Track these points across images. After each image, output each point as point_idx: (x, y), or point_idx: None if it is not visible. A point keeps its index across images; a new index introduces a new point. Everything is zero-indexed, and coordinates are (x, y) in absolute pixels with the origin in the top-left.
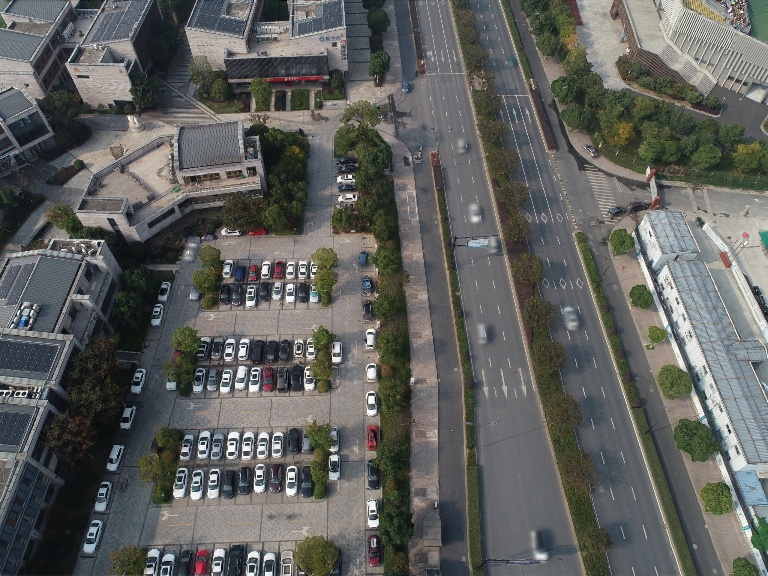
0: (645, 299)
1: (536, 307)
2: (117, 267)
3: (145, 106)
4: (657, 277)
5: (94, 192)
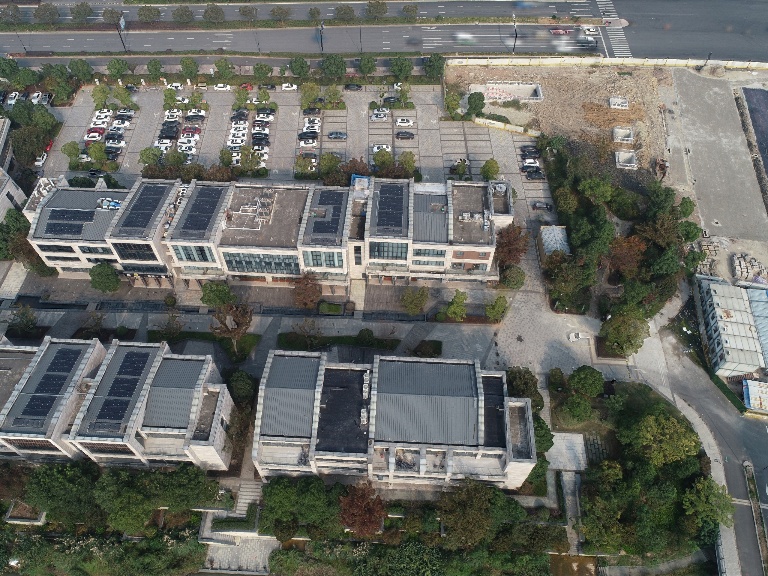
0: None
1: None
2: None
3: None
4: None
5: None
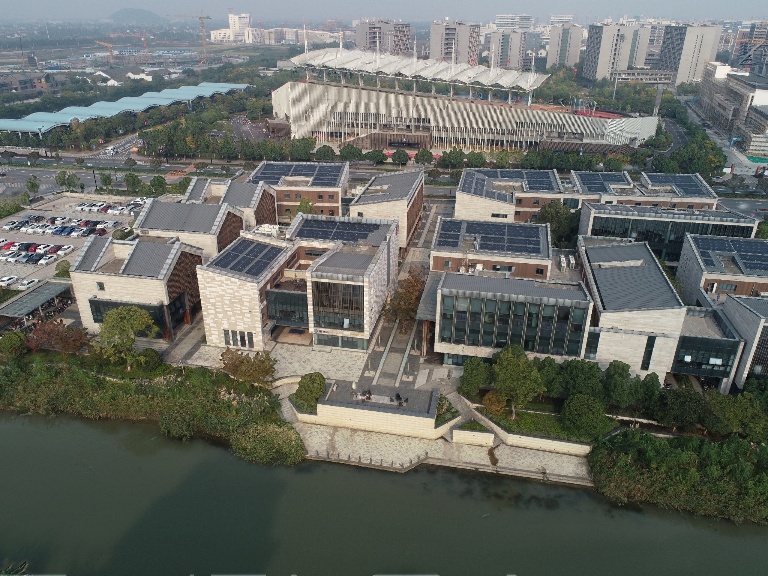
0: None
1: None
2: None
3: None
4: None
5: None
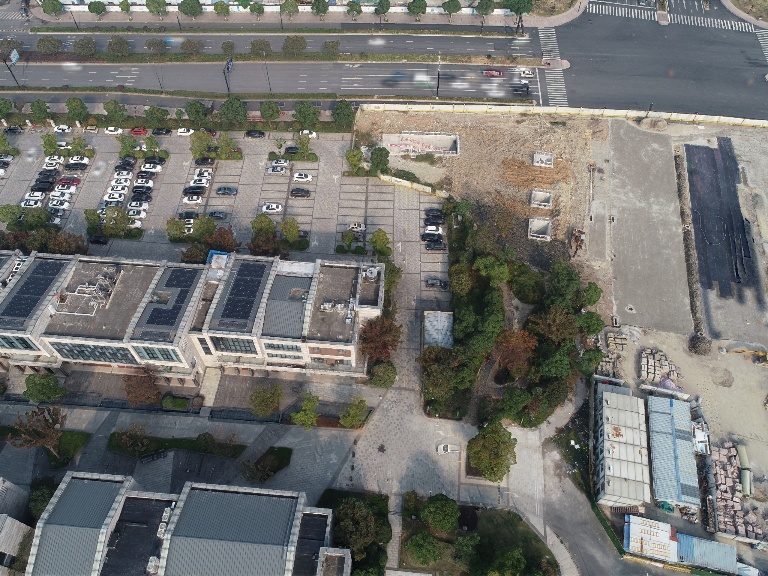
0: (99, 4)
1: None
2: None
3: None
4: None
5: None
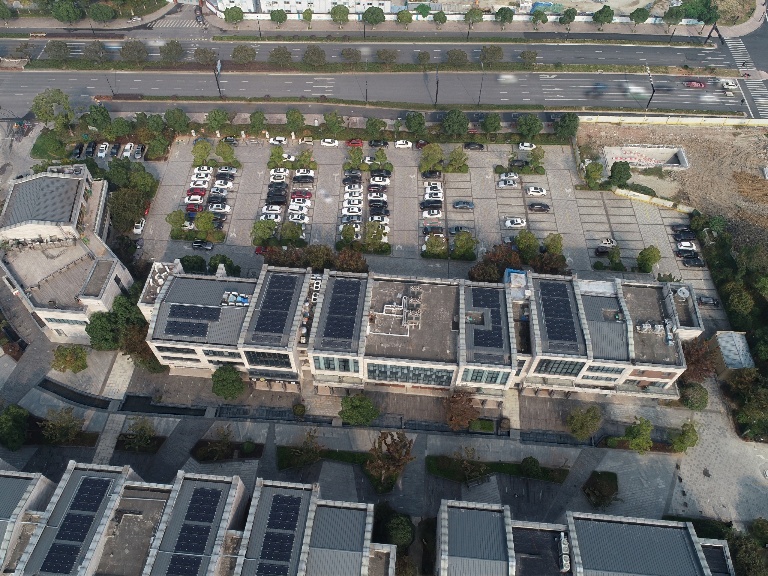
0: None
1: None
2: None
3: None
4: (262, 12)
5: None
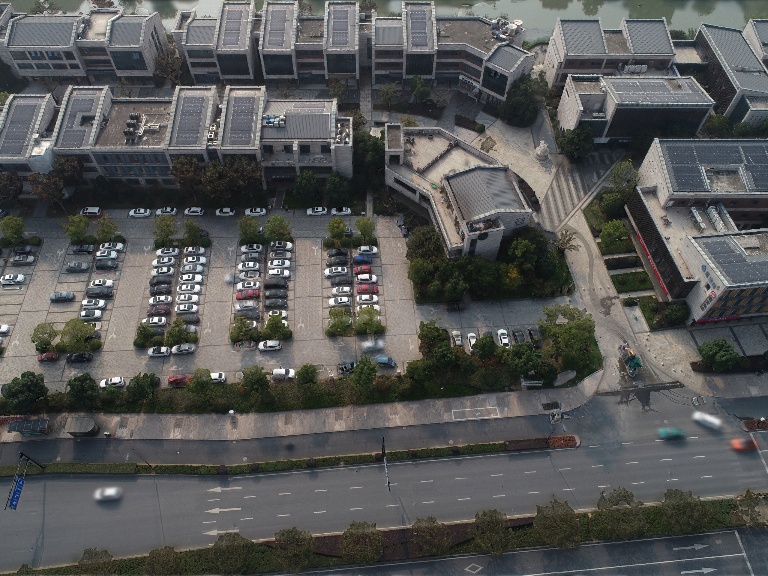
0: None
1: (299, 544)
2: (349, 170)
3: (561, 150)
4: None
5: (423, 135)
